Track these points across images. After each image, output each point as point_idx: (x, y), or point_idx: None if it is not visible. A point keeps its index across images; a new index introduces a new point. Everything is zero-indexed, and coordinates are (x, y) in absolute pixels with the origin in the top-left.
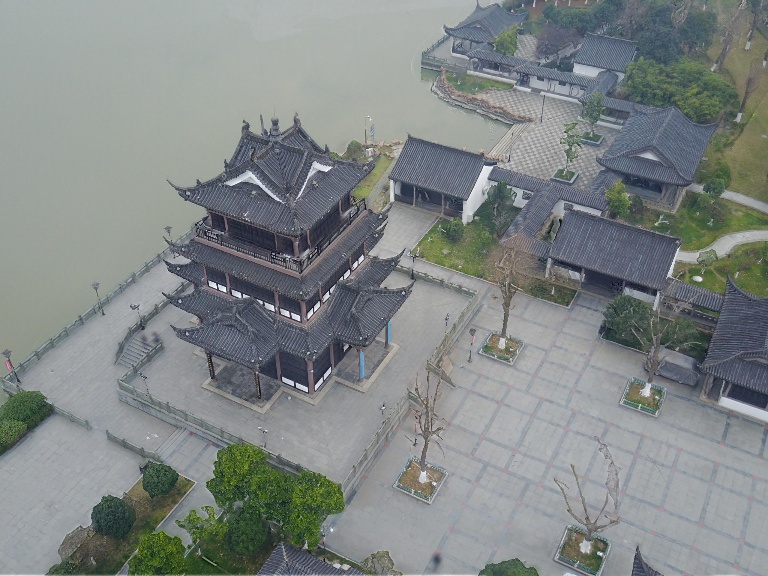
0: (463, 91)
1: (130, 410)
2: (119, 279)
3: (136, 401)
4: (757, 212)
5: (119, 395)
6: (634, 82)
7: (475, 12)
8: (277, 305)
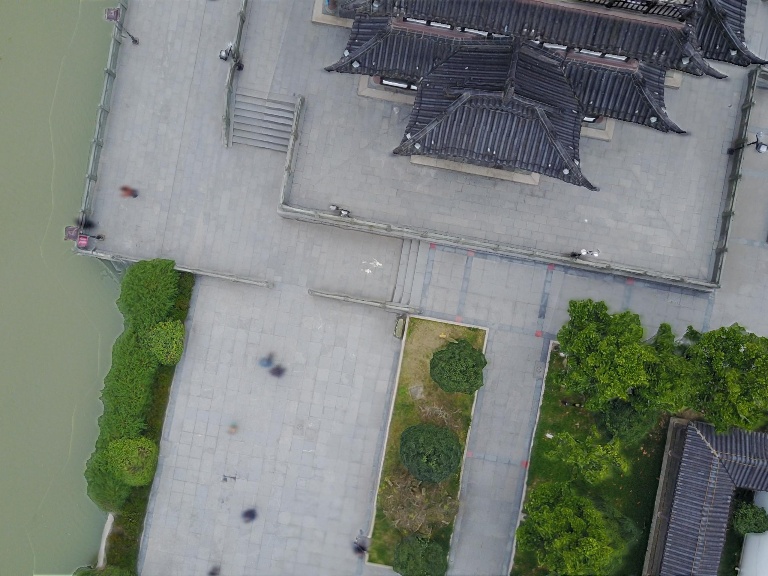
0: None
1: (310, 230)
2: None
3: None
4: None
5: (281, 214)
6: None
7: None
8: None
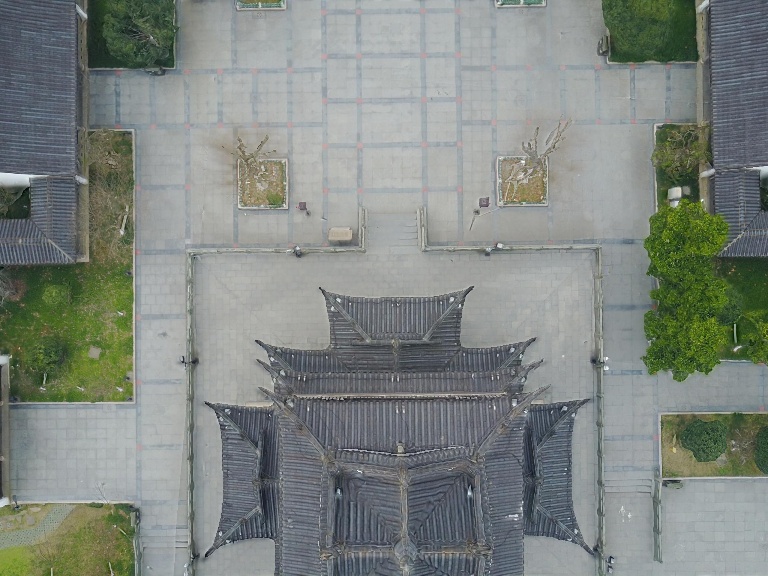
0: None
1: None
2: None
3: None
4: None
5: None
6: None
7: None
8: None
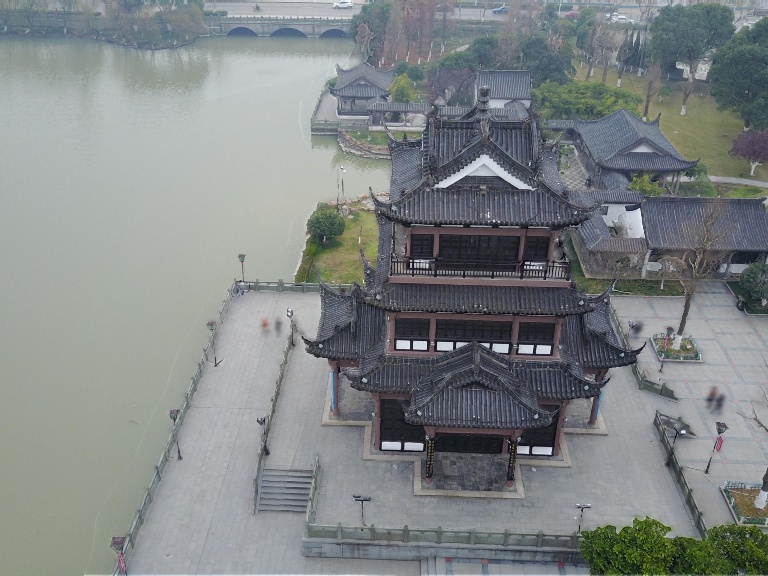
0: (380, 145)
1: (332, 564)
2: (155, 413)
3: (341, 546)
4: (739, 185)
5: (305, 549)
6: (553, 103)
7: (341, 75)
8: (515, 341)
